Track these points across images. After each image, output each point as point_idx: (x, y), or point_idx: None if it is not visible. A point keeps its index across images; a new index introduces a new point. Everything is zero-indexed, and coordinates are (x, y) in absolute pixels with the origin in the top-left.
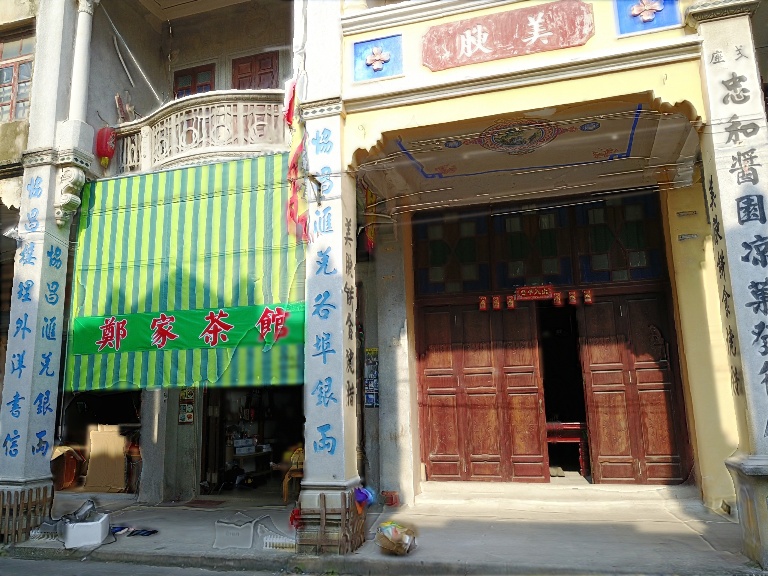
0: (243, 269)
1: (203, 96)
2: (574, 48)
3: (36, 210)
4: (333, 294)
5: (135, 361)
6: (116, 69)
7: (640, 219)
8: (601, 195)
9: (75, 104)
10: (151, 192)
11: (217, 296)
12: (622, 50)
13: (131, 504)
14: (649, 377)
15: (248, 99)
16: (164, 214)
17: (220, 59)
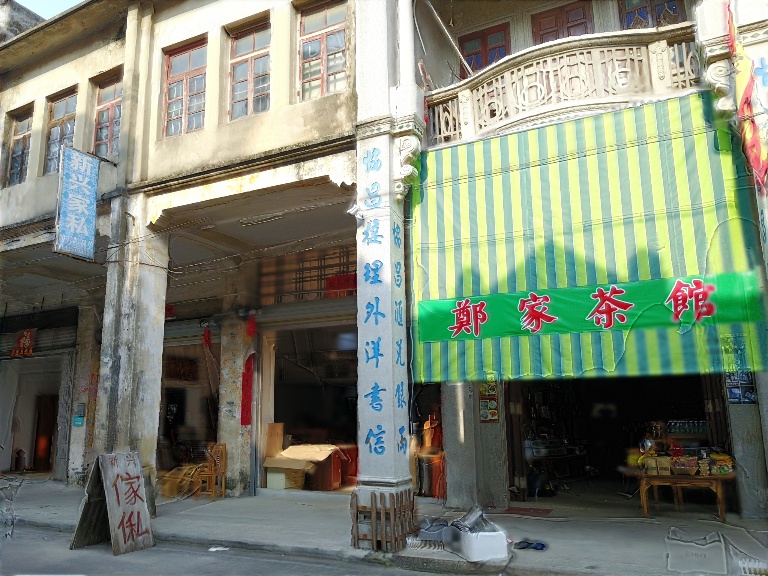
0: (640, 236)
1: (552, 45)
2: None
3: (377, 184)
4: None
5: (502, 348)
6: (414, 35)
7: None
8: None
9: (406, 67)
10: (500, 157)
11: (606, 270)
12: None
13: (441, 509)
14: None
15: (605, 44)
16: (520, 180)
17: (515, 17)
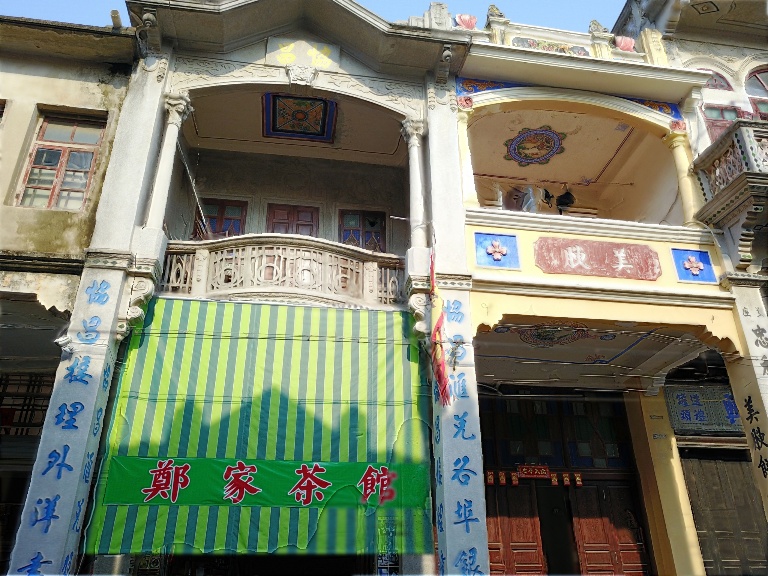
0: (344, 421)
1: (293, 238)
2: (650, 282)
3: (97, 318)
4: (473, 460)
5: (199, 517)
6: None
7: (611, 416)
8: (581, 391)
9: (156, 212)
10: (232, 322)
11: (313, 448)
12: (686, 292)
13: None
14: (630, 558)
15: (334, 251)
16: (247, 348)
17: (254, 199)
